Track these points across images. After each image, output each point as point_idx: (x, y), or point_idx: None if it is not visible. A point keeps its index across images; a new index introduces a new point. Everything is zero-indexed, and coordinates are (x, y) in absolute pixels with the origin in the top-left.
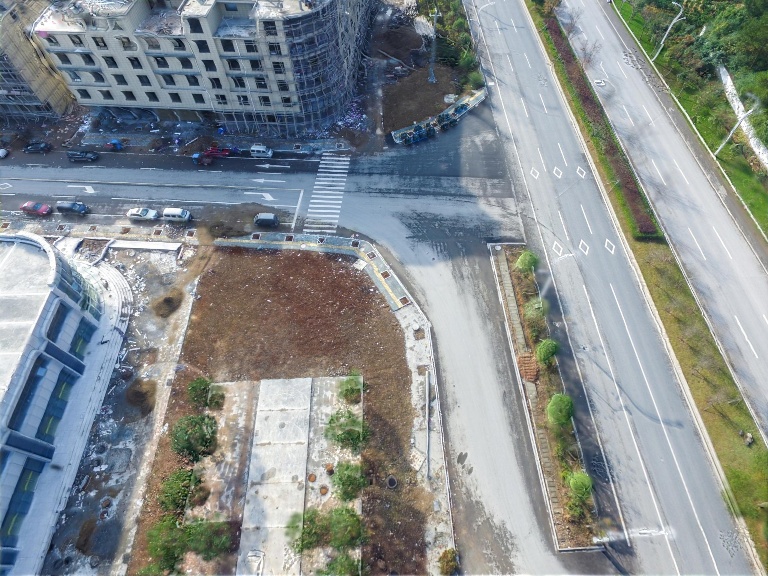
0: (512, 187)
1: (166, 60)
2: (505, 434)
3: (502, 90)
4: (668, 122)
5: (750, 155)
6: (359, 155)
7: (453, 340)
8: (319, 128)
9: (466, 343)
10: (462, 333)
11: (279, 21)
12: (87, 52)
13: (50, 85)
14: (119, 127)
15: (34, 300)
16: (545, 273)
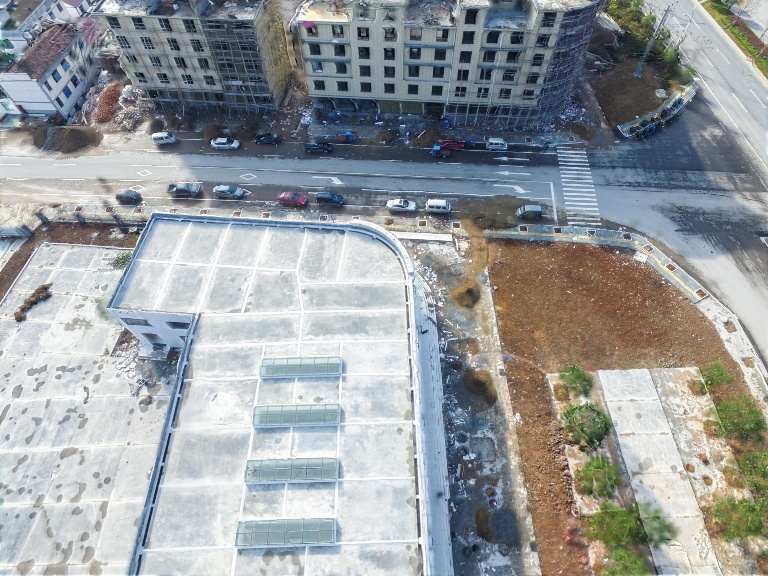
0: (762, 181)
1: (421, 51)
2: None
3: (710, 85)
4: None
5: None
6: (594, 149)
7: (766, 333)
8: (544, 121)
9: None
10: None
11: (562, 12)
12: (343, 43)
13: (279, 76)
14: (341, 119)
15: (393, 288)
16: None
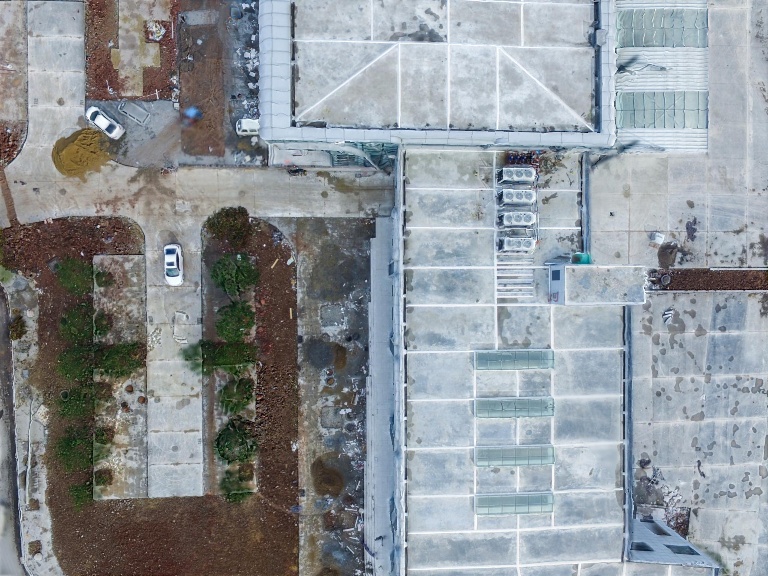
0: None
1: None
2: None
3: None
4: None
5: None
6: None
7: None
8: None
9: None
10: None
11: None
12: None
13: None
14: None
15: None
16: None
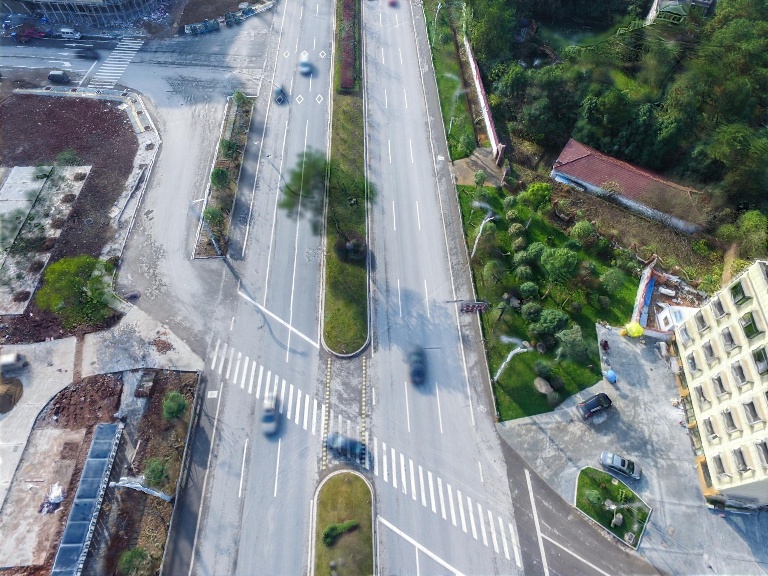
0: (265, 63)
1: None
2: (186, 201)
3: (289, 1)
4: (410, 25)
5: (461, 48)
6: (152, 39)
7: (174, 151)
8: (126, 20)
9: (183, 152)
10: (182, 147)
11: None
12: None
13: None
14: None
15: None
16: (262, 114)
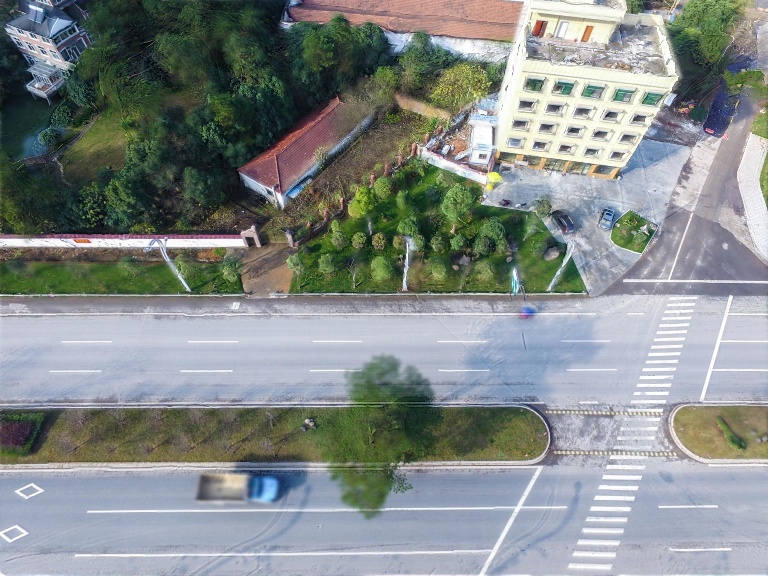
0: None
1: None
2: None
3: None
4: None
5: None
6: None
7: None
8: None
9: None
10: None
11: None
12: None
13: None
14: None
15: None
16: None
